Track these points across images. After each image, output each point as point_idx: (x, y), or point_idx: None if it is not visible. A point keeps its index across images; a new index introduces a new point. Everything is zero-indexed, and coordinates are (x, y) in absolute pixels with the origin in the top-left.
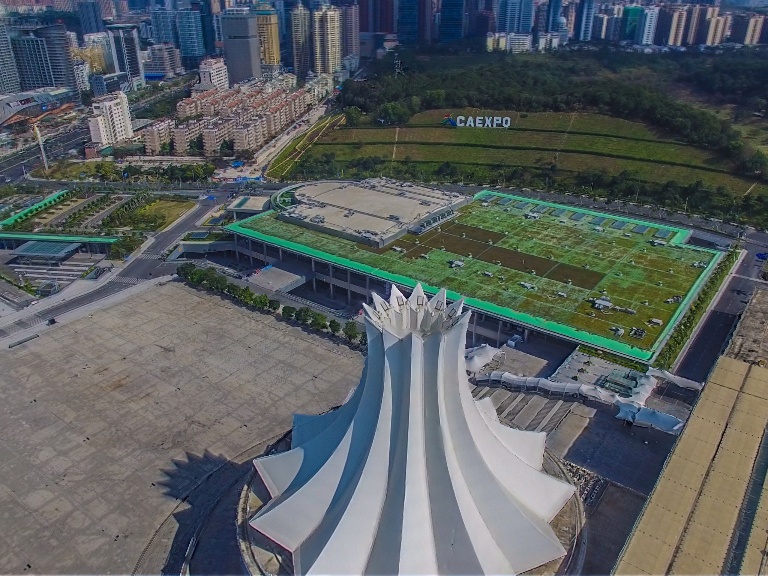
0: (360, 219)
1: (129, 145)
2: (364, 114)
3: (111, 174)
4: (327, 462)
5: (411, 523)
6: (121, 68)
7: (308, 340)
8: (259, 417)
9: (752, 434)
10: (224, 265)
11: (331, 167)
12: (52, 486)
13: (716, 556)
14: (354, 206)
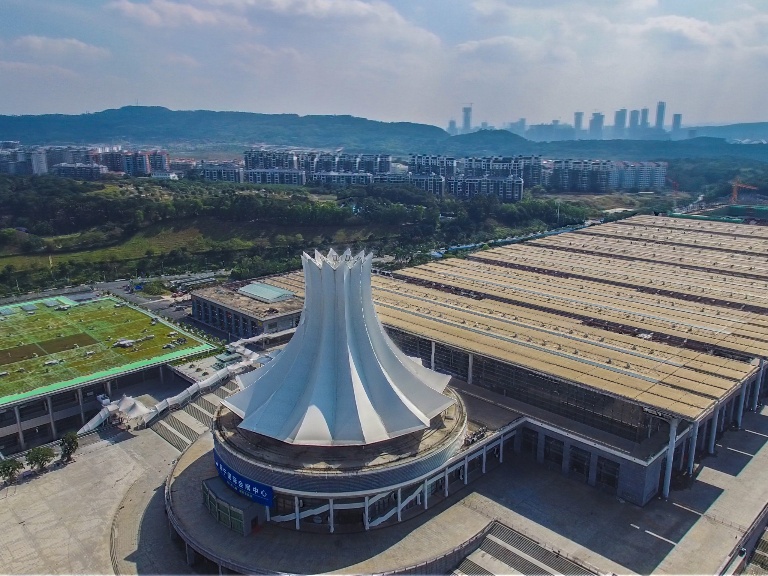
0: None
1: None
2: None
3: None
4: (353, 381)
5: None
6: None
7: None
8: (60, 570)
9: None
10: None
11: None
12: None
13: None
14: None
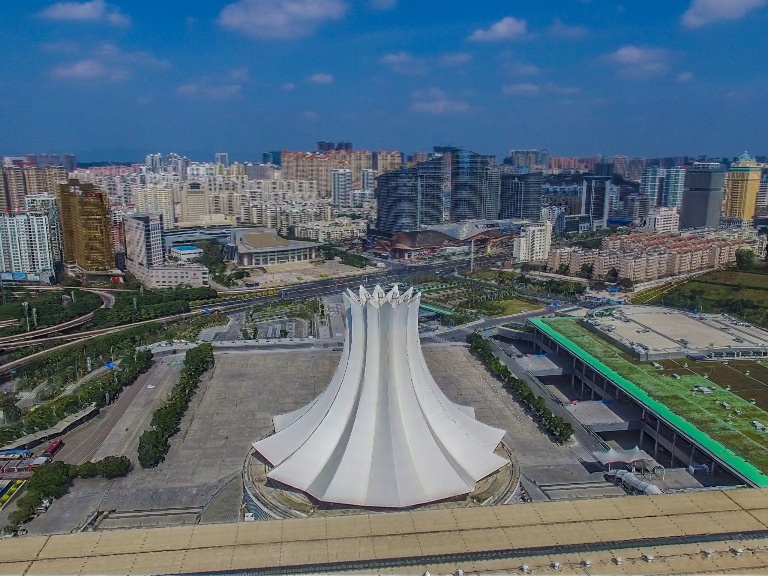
0: (649, 336)
1: (542, 264)
2: (761, 259)
3: (507, 279)
4: (321, 393)
5: (322, 436)
6: (586, 211)
7: (507, 404)
8: None
9: (683, 529)
10: (521, 351)
11: (695, 303)
12: (275, 413)
13: (479, 547)
14: (657, 327)
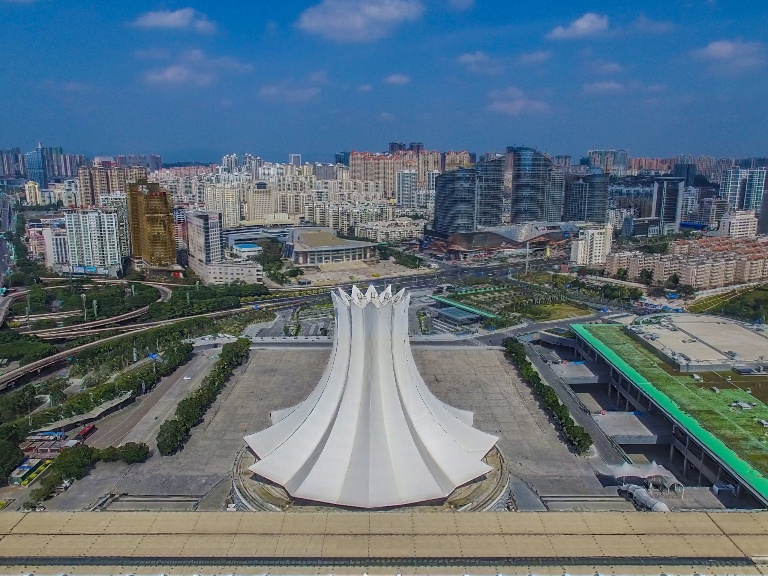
0: (694, 347)
1: (601, 268)
2: None
3: (560, 283)
4: None
5: (306, 433)
6: (657, 214)
7: (532, 411)
8: None
9: (650, 549)
10: (562, 358)
11: (758, 313)
12: None
13: (428, 552)
14: (706, 337)
